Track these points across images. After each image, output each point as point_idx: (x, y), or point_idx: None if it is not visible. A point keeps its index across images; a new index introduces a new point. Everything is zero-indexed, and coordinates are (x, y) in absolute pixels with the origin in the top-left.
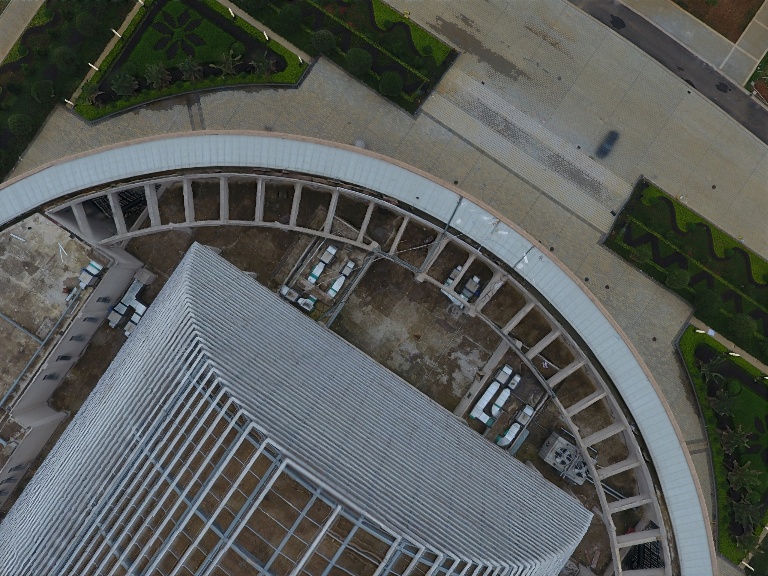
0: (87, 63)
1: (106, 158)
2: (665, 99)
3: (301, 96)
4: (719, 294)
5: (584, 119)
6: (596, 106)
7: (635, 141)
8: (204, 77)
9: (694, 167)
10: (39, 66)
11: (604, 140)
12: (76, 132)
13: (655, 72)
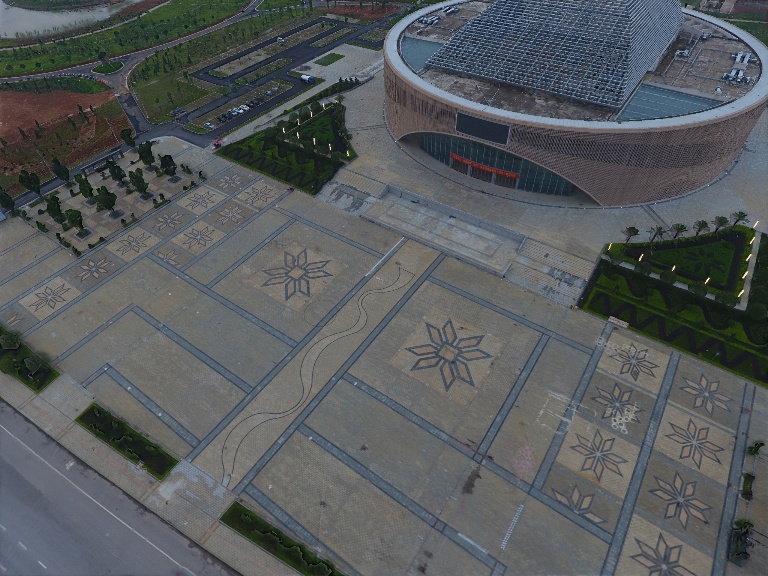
0: None
1: None
2: None
3: None
4: None
5: None
6: None
7: None
8: None
9: None
10: None
11: None
12: None
13: None
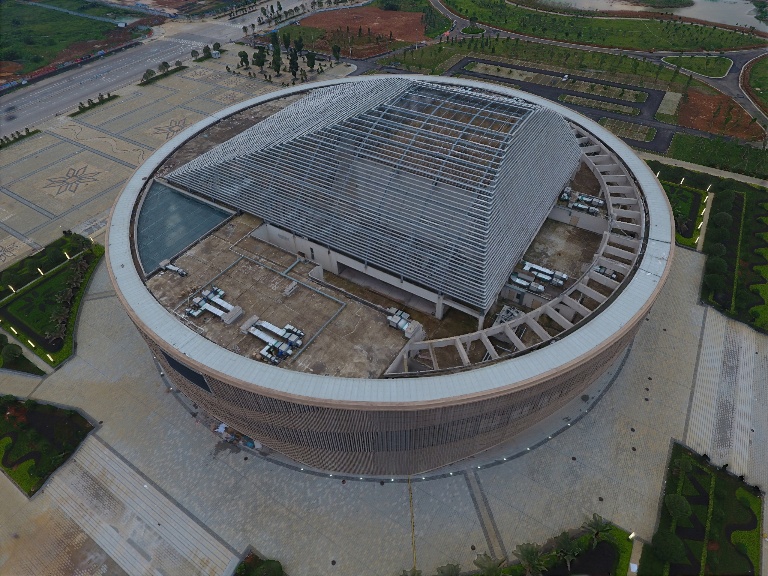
0: None
1: (606, 133)
2: None
3: None
4: (684, 552)
5: None
6: None
7: None
8: None
9: None
10: None
11: None
12: None
13: None
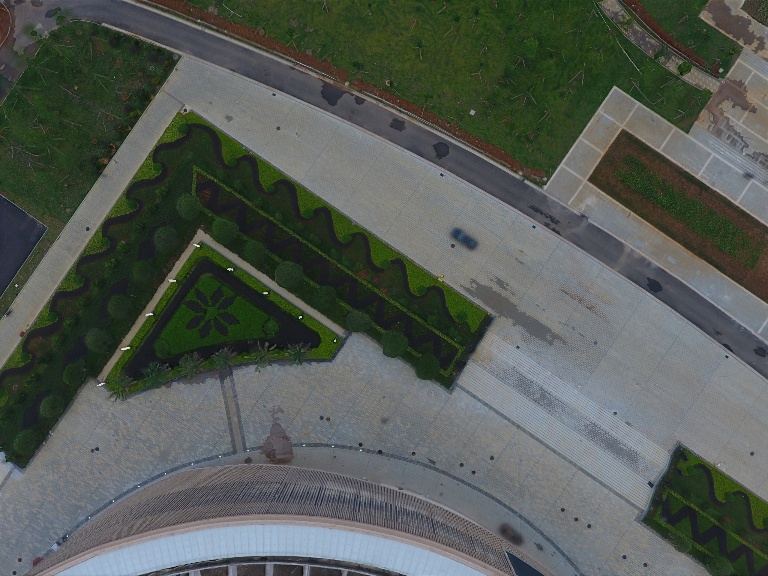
0: (118, 337)
1: (150, 547)
2: (702, 364)
3: (335, 369)
4: None
5: (620, 384)
6: (633, 371)
7: (672, 407)
8: (237, 353)
9: (732, 433)
10: (69, 332)
11: (641, 406)
12: (107, 406)
13: (692, 336)
